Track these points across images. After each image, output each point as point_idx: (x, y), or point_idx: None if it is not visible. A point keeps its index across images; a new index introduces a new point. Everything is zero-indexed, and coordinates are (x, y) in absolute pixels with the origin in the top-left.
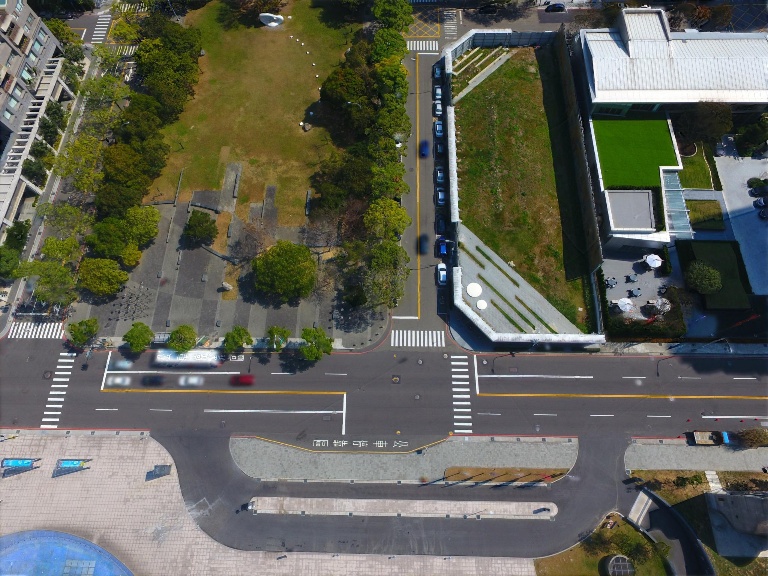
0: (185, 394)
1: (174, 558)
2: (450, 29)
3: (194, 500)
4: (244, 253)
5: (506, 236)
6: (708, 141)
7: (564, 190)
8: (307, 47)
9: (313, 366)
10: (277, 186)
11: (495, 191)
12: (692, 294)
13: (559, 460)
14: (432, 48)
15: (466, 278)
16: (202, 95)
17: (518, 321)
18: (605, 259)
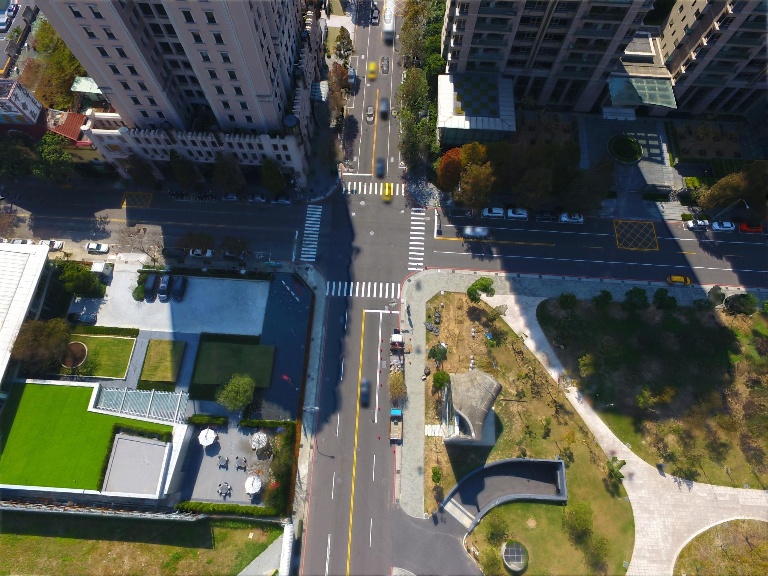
0: None
1: None
2: None
3: None
4: None
5: None
6: (73, 326)
7: (89, 527)
8: None
9: None
10: None
11: None
12: None
13: None
14: None
15: None
16: None
17: None
18: (194, 488)
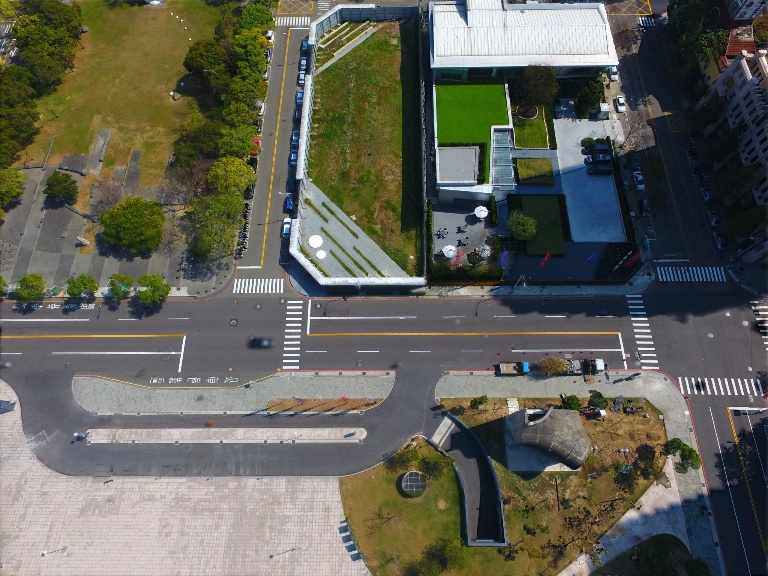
0: (36, 339)
1: (9, 484)
2: (323, 6)
3: (34, 433)
4: (104, 211)
5: (350, 192)
6: (550, 105)
7: (409, 150)
8: (186, 23)
9: (158, 312)
10: (142, 150)
11: (344, 152)
12: (516, 242)
13: (375, 391)
14: (304, 23)
15: (309, 231)
16: (81, 68)
17: (353, 269)
18: (441, 212)
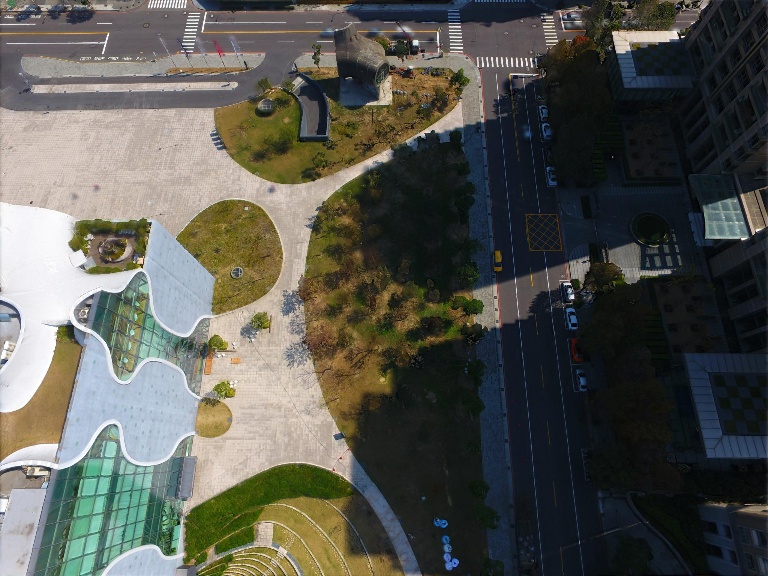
0: None
1: None
2: None
3: None
4: None
5: None
6: None
7: None
8: None
9: (89, 20)
10: None
11: None
12: None
13: (248, 64)
14: None
15: None
16: None
17: None
18: None
